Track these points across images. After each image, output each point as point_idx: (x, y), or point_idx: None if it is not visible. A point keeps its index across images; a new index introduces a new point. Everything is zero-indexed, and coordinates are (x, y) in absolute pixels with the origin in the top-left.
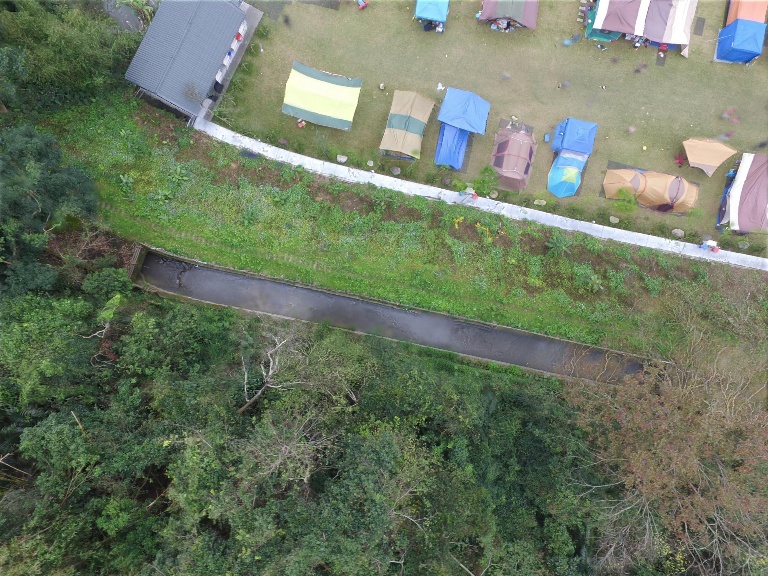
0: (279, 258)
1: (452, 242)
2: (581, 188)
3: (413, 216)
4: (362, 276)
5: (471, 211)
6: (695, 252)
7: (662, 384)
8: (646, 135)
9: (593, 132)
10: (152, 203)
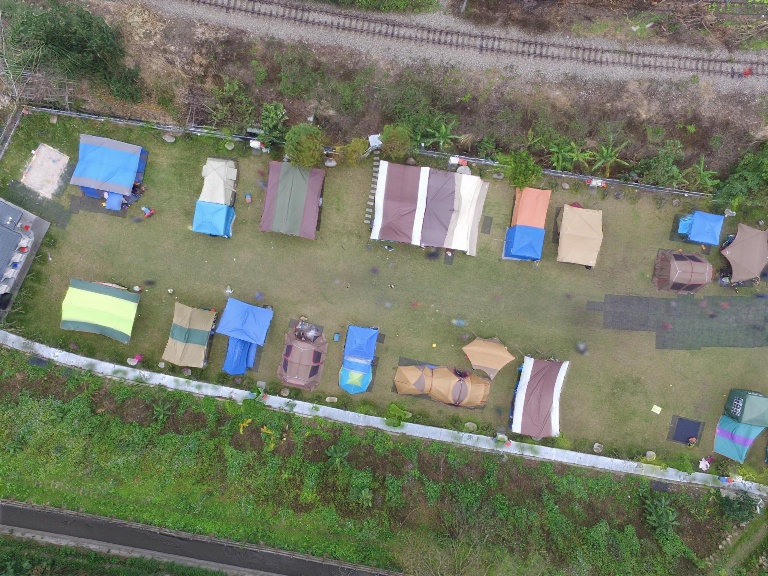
0: (45, 485)
1: (230, 454)
2: (373, 384)
3: (198, 422)
4: (128, 501)
5: (260, 412)
6: (489, 444)
7: None
8: (436, 332)
9: (373, 340)
10: None
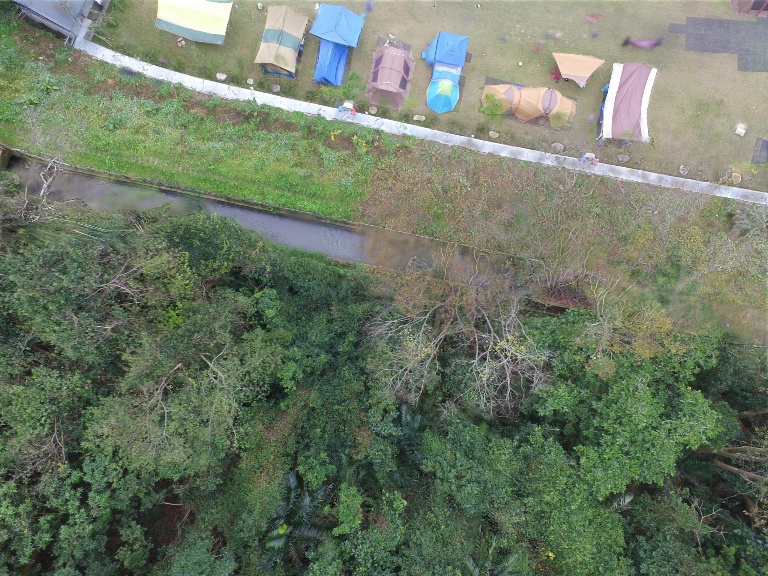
0: (144, 161)
1: (324, 150)
2: (460, 104)
3: (289, 129)
4: (227, 178)
5: (349, 126)
6: (575, 165)
7: (531, 283)
8: (522, 52)
9: (464, 44)
10: (17, 107)
